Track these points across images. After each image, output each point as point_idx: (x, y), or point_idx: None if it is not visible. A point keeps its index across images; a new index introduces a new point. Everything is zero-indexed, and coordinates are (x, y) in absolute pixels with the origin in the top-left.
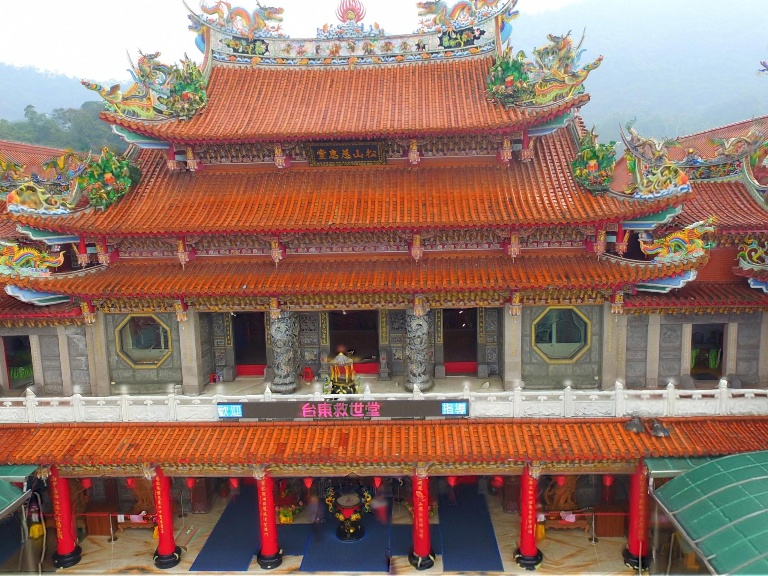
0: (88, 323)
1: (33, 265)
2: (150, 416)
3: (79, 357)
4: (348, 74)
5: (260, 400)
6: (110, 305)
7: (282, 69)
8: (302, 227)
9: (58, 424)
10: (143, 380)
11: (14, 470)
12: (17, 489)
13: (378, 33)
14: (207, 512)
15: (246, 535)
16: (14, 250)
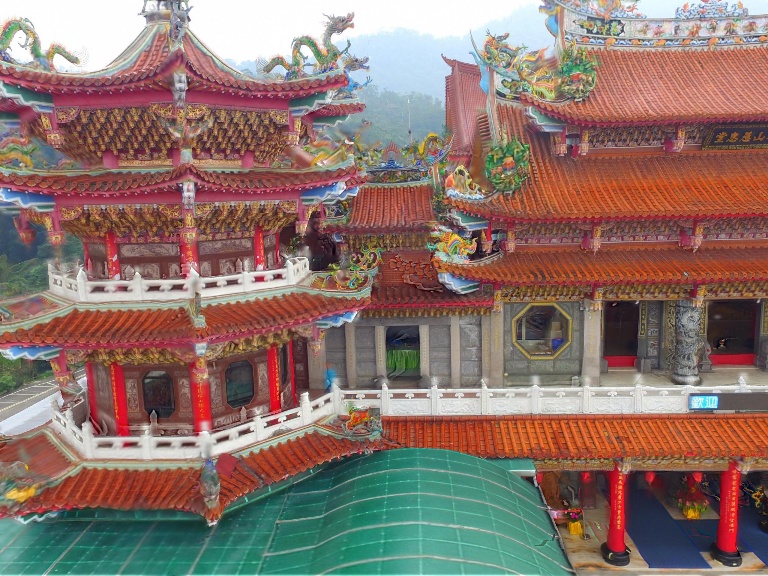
0: (494, 312)
1: (458, 252)
2: (612, 408)
3: (469, 348)
4: (711, 55)
5: (735, 391)
6: (514, 294)
7: (637, 50)
8: (748, 211)
9: (519, 416)
10: (538, 371)
11: (512, 464)
12: (528, 483)
13: (742, 12)
14: (595, 507)
15: (666, 531)
16: (449, 236)
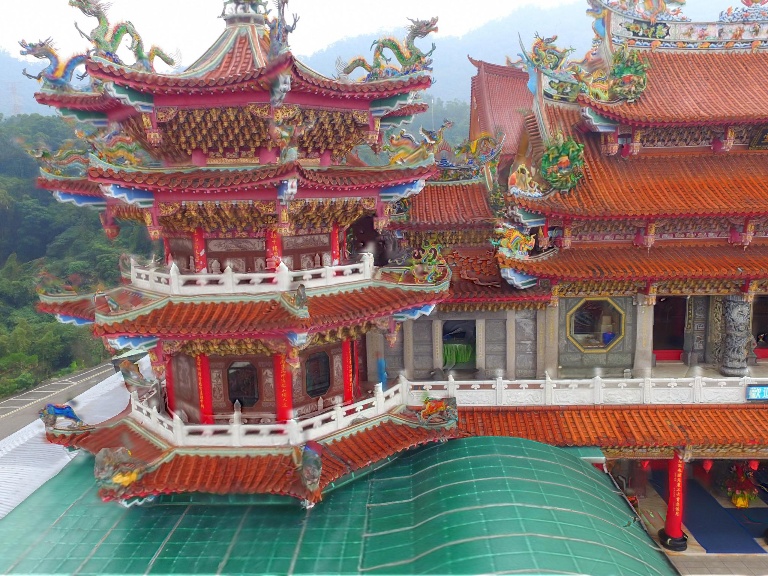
0: (551, 307)
1: (518, 248)
2: (672, 398)
3: (524, 341)
4: (754, 57)
5: None
6: (570, 289)
7: (682, 53)
8: None
9: (582, 406)
10: (591, 364)
11: (581, 451)
12: (598, 470)
13: None
14: (645, 496)
15: (717, 519)
16: (511, 233)
